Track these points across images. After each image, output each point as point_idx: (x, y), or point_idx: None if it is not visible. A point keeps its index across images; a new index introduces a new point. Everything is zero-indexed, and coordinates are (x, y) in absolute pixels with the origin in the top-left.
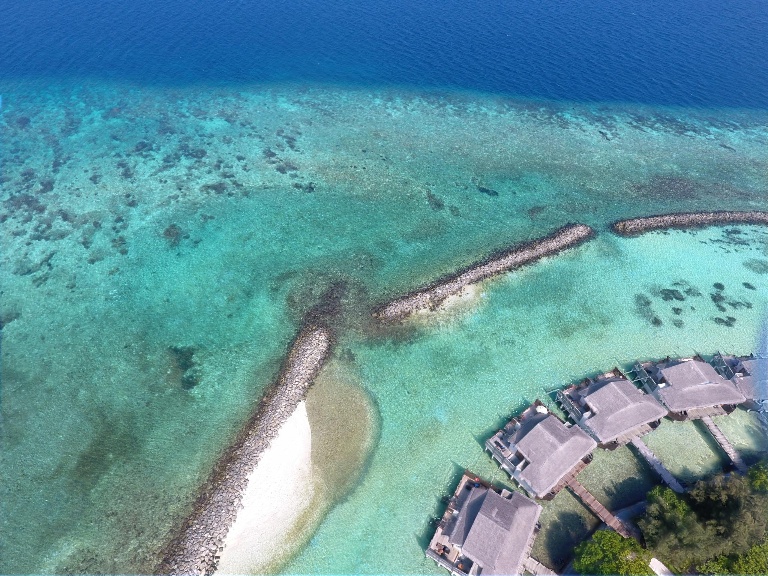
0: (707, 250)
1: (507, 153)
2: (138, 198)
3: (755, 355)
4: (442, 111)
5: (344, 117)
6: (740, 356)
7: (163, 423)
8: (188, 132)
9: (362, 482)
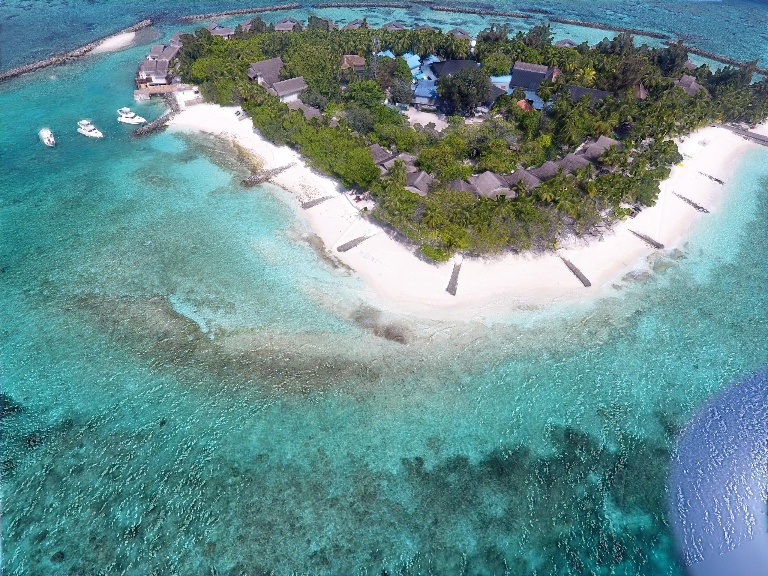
0: (352, 12)
1: None
2: None
3: None
4: None
5: None
6: None
7: (78, 34)
8: None
9: (150, 44)
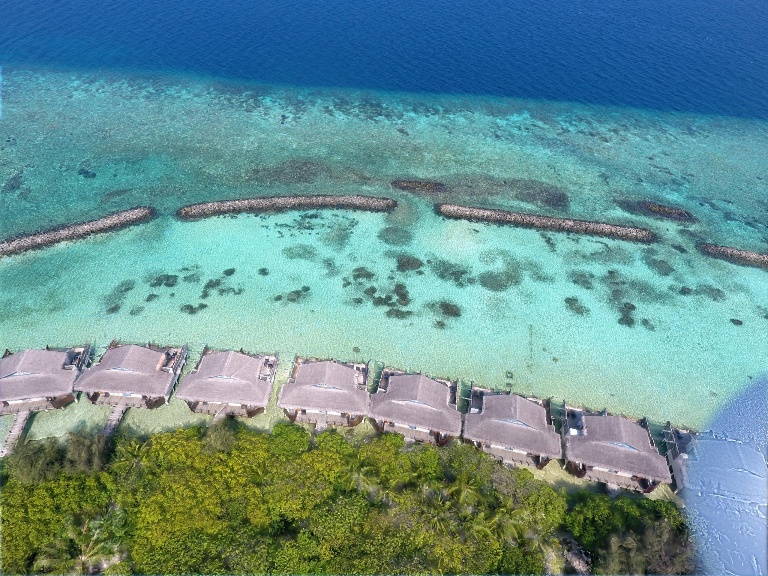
0: (258, 234)
1: (154, 136)
2: None
3: None
4: (133, 94)
5: (17, 98)
6: (164, 345)
7: None
8: None
9: None
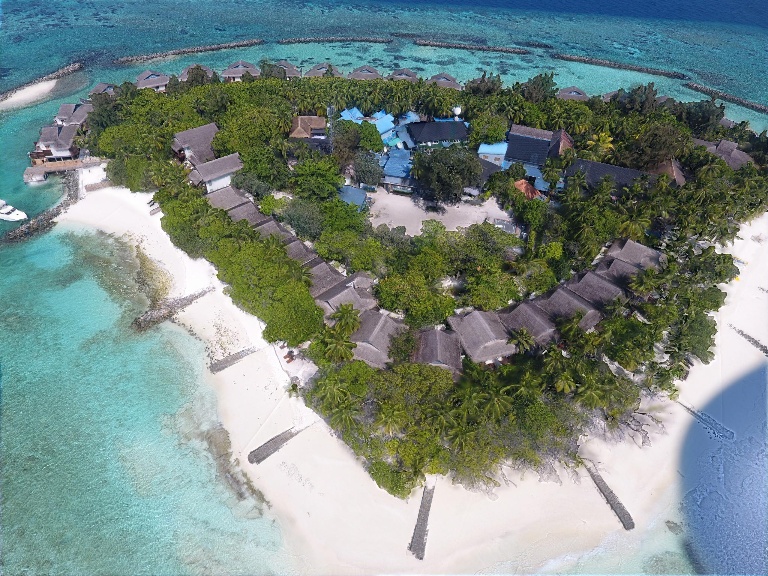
0: None
1: (249, 17)
2: (4, 27)
3: None
4: (227, 1)
5: (158, 2)
6: None
7: None
8: (49, 6)
9: (70, 96)
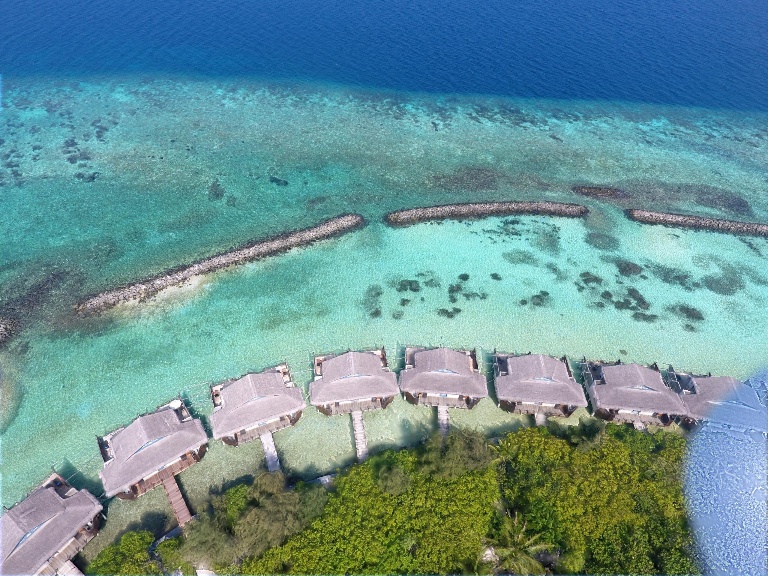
0: (473, 240)
1: (322, 143)
2: None
3: (459, 347)
4: (280, 102)
5: (173, 107)
6: None
7: None
8: None
9: None
